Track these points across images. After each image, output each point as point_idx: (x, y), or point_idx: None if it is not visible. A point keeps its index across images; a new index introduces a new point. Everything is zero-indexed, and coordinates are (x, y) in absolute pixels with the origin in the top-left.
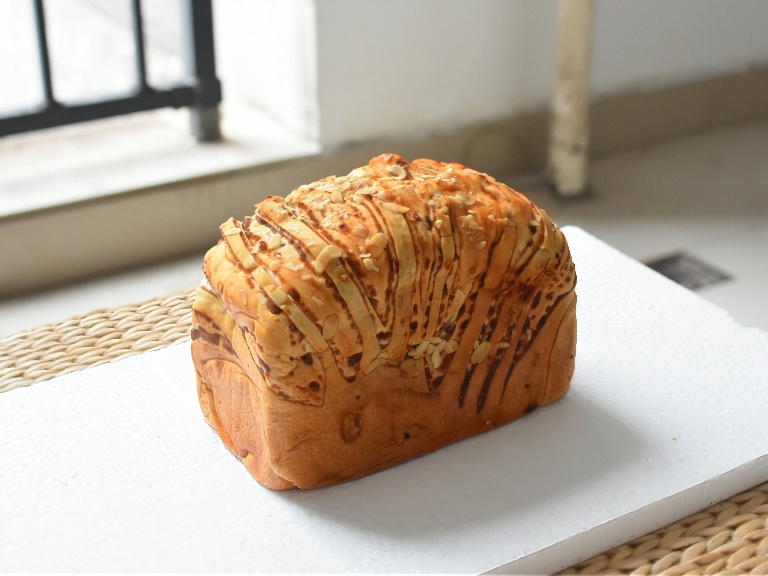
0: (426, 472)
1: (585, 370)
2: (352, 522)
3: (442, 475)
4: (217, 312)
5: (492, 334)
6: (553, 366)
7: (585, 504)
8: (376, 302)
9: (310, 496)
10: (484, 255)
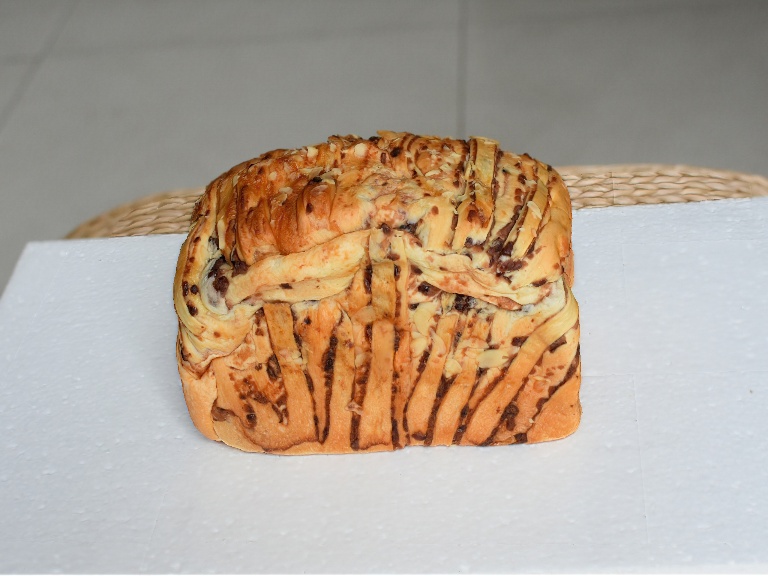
0: None
1: None
2: None
3: None
4: None
5: None
6: None
7: None
8: None
9: None
10: None
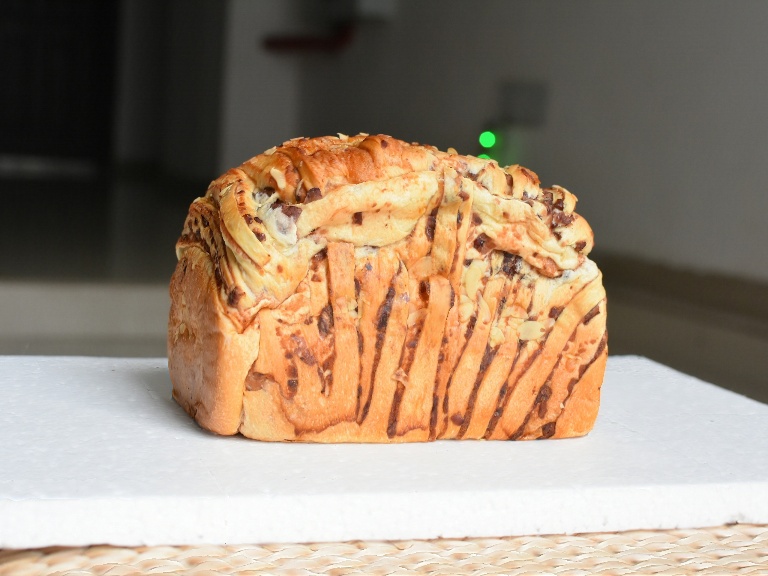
0: None
1: None
2: None
3: None
4: None
5: None
6: None
7: None
8: None
9: None
10: None
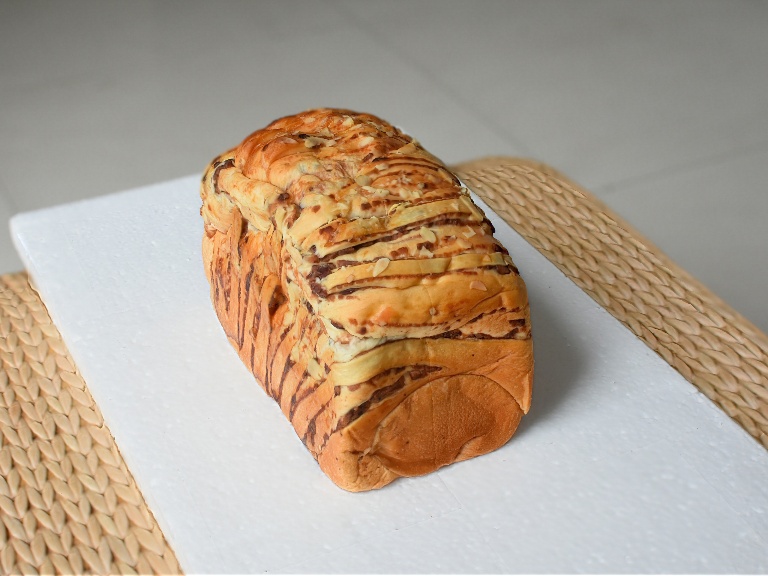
0: None
1: None
2: (560, 393)
3: None
4: (398, 355)
5: None
6: None
7: None
8: None
9: None
10: None
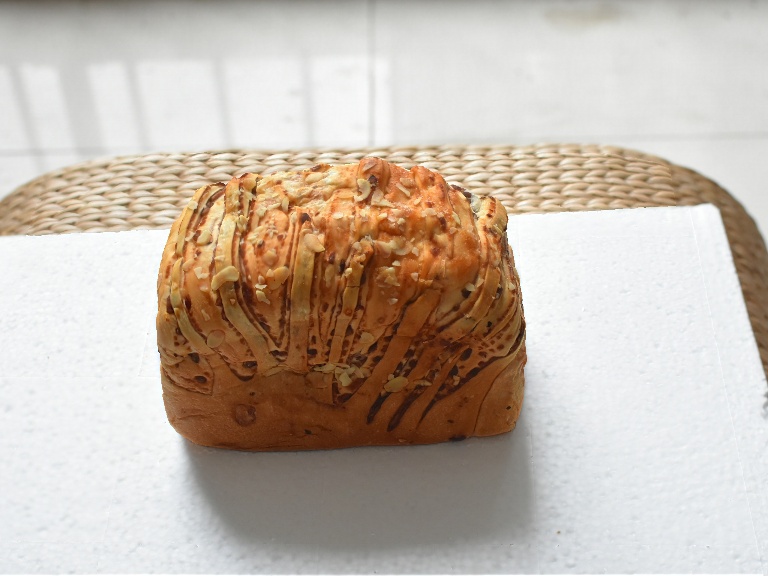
0: (315, 470)
1: (556, 408)
2: (213, 498)
3: (324, 479)
4: None
5: (410, 372)
6: (485, 411)
7: (412, 570)
8: (269, 327)
9: (206, 454)
10: (394, 311)
